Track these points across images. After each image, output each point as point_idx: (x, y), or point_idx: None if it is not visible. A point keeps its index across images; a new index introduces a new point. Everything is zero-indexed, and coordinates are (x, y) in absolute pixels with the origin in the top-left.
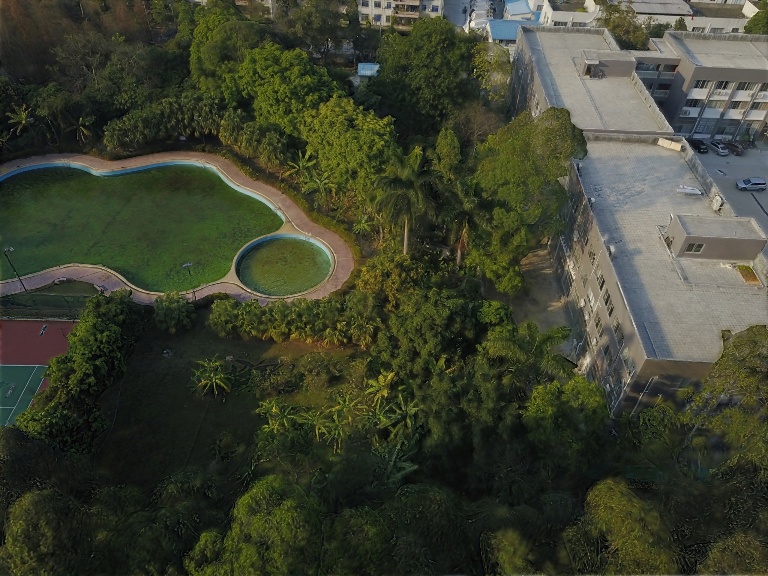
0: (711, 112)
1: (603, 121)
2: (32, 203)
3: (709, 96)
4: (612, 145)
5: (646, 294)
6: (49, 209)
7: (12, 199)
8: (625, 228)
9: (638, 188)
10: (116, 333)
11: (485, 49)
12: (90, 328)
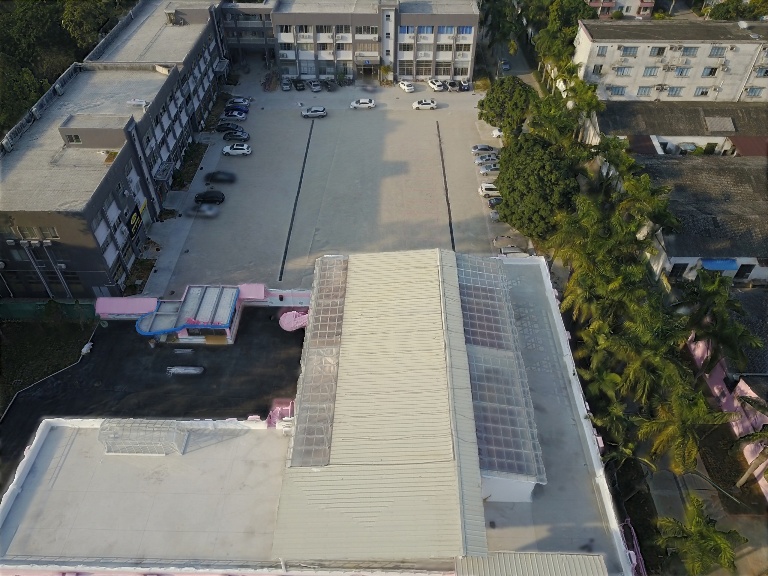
0: (307, 54)
1: (142, 57)
2: None
3: (296, 39)
4: (118, 73)
5: (10, 173)
6: None
7: None
8: (51, 130)
9: (99, 102)
10: None
11: (75, 3)
12: None
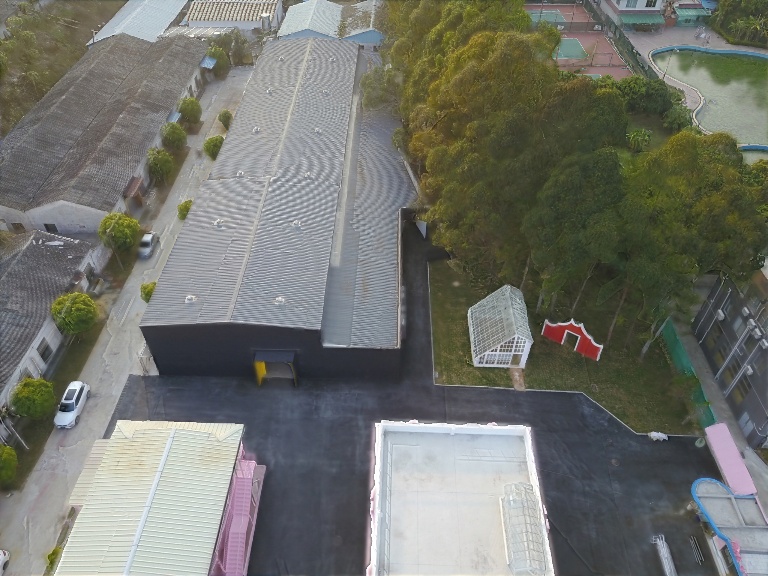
0: None
1: None
2: (742, 69)
3: None
4: None
5: None
6: (742, 76)
7: (739, 63)
8: None
9: None
10: (640, 91)
11: None
12: (634, 77)
